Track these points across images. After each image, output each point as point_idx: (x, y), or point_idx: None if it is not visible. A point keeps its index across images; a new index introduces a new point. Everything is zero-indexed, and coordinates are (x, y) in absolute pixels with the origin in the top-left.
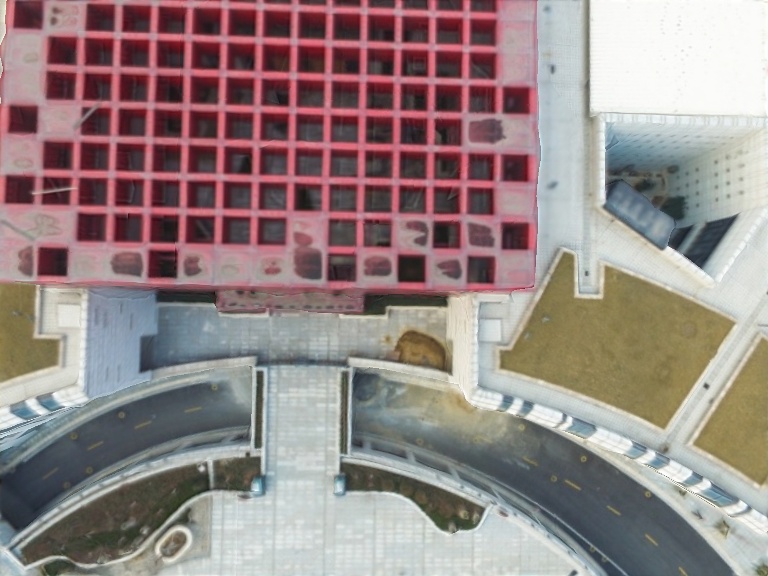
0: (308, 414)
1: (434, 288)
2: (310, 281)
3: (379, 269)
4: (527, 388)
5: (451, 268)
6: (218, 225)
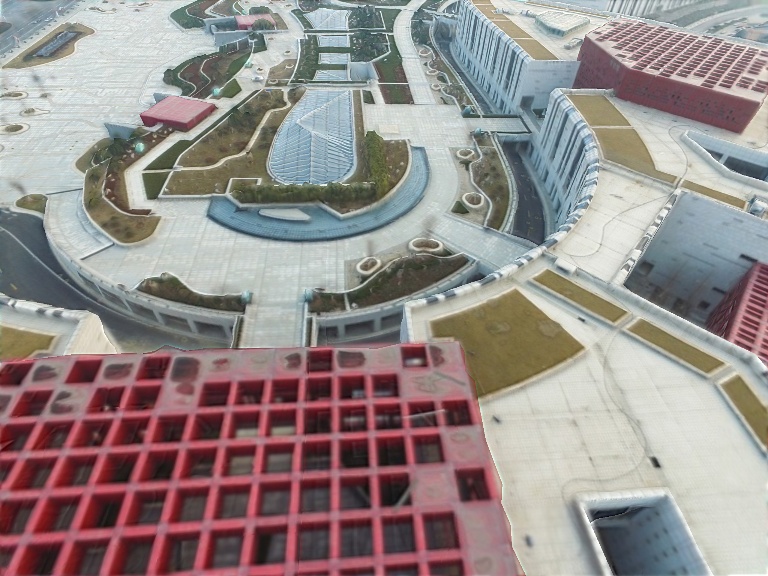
0: (268, 342)
1: (70, 357)
2: (187, 355)
3: (118, 369)
4: (38, 325)
5: (44, 374)
6: (266, 395)
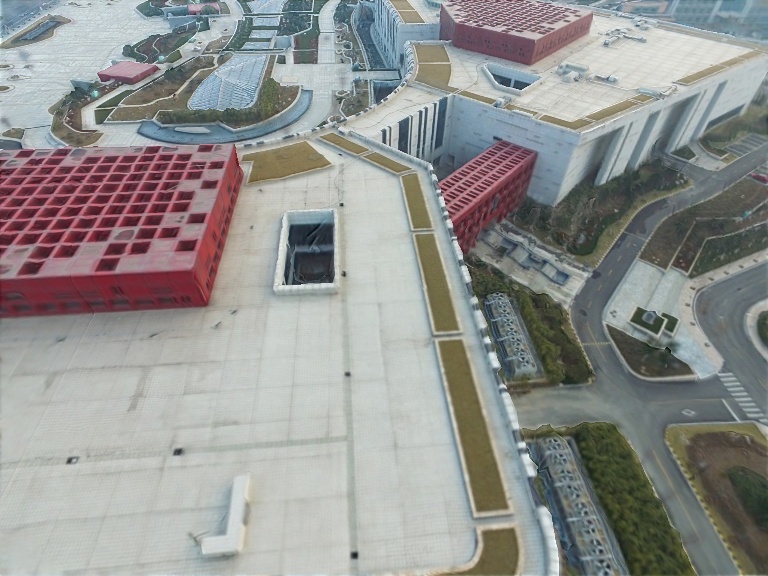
0: None
1: None
2: None
3: None
4: None
5: (3, 155)
6: (119, 160)
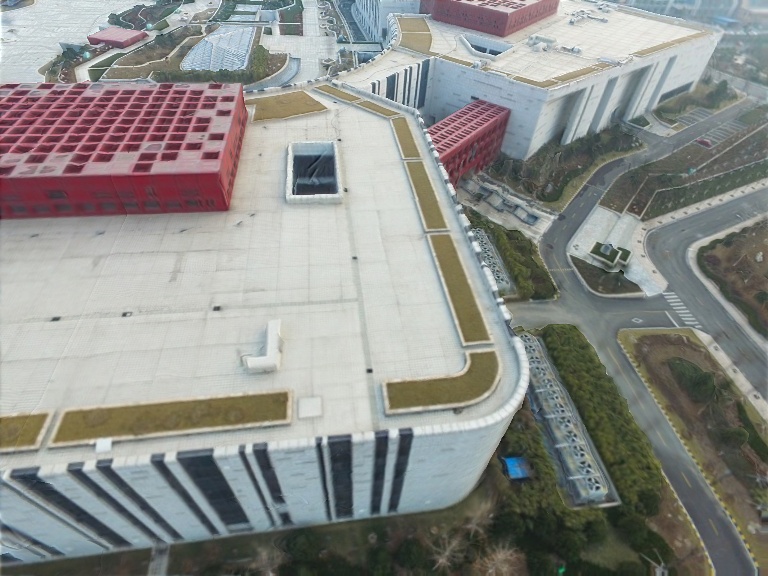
0: None
1: None
2: None
3: None
4: None
5: None
6: (136, 93)
